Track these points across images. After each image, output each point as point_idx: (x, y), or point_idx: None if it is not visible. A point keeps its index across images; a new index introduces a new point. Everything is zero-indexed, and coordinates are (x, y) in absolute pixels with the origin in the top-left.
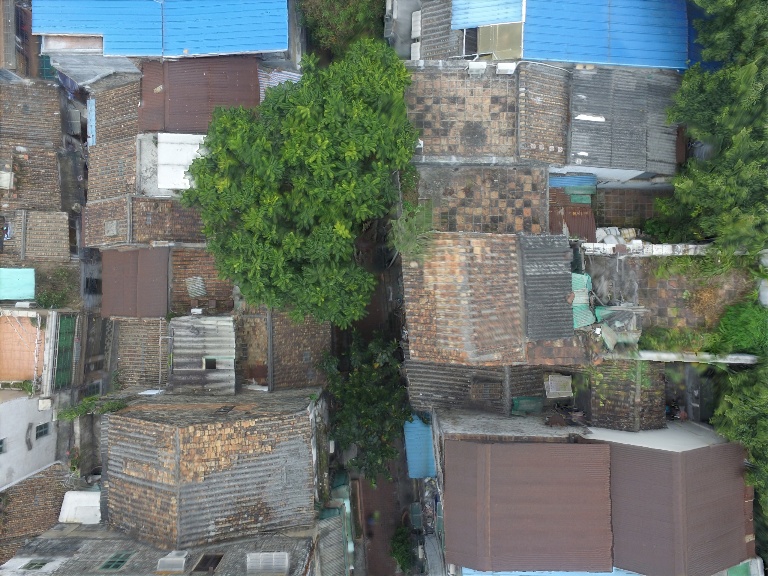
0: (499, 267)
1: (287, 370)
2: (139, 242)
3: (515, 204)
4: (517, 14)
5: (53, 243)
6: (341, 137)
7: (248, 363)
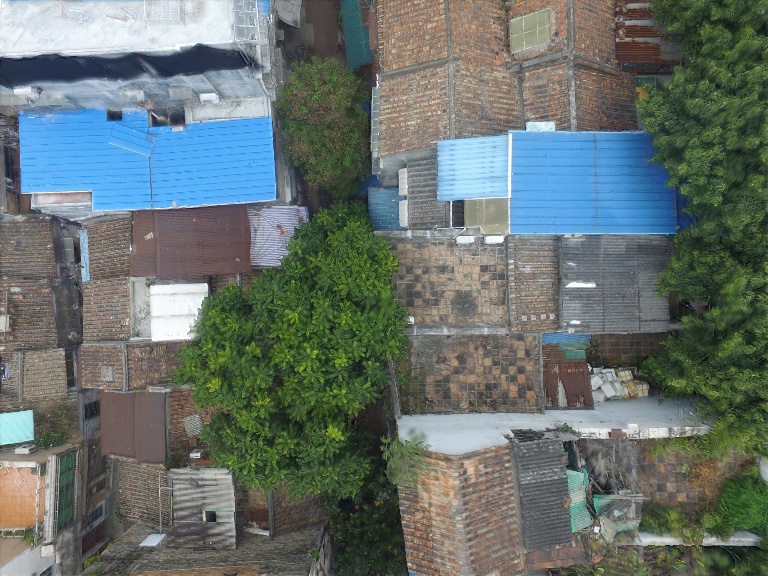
0: (494, 481)
1: (288, 511)
2: (135, 388)
3: (509, 371)
4: (503, 189)
5: (50, 381)
6: (330, 344)
7: (248, 505)
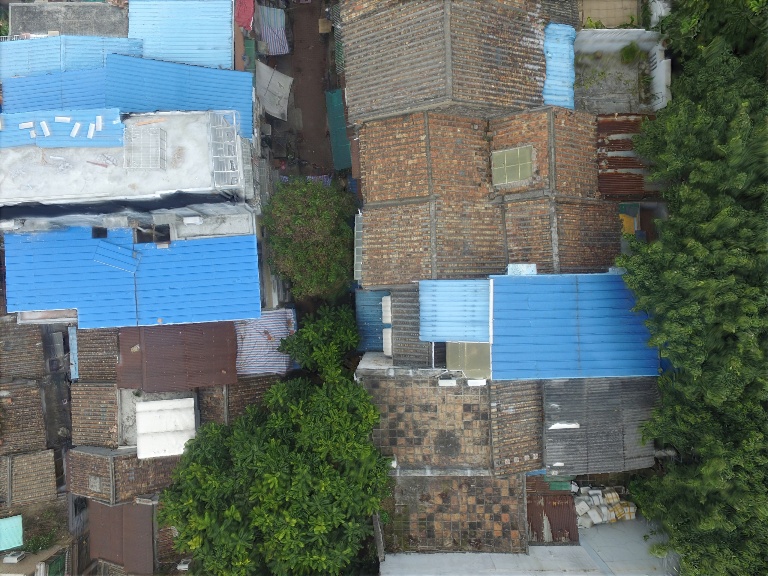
0: None
1: None
2: (123, 500)
3: (493, 510)
4: (484, 334)
5: (39, 483)
6: (309, 510)
7: None
